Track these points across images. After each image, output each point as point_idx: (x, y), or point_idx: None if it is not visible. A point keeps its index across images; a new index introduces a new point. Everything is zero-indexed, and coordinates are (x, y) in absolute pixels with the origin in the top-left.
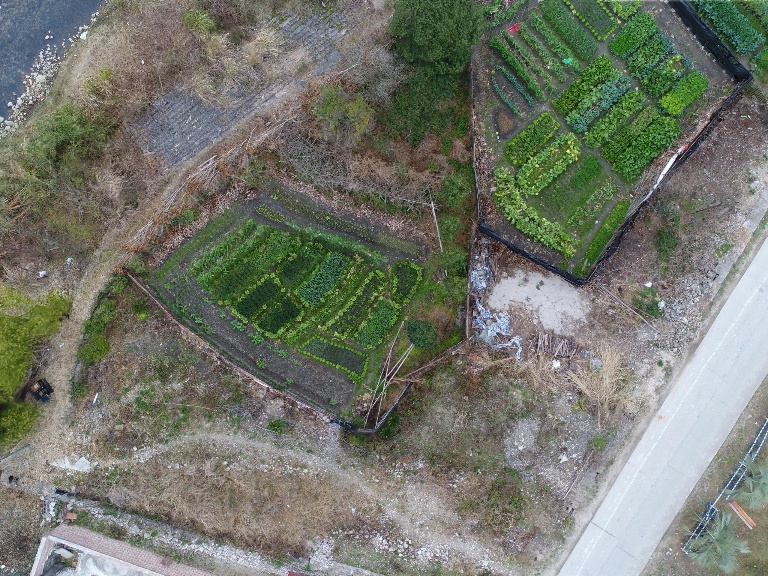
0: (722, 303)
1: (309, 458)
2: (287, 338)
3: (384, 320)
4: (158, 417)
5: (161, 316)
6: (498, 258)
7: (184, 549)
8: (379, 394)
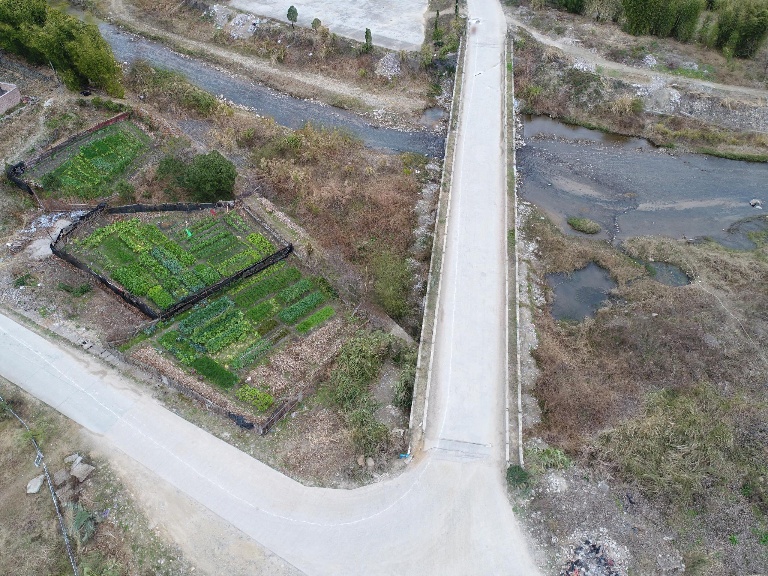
0: (7, 315)
1: None
2: None
3: None
4: None
5: None
6: None
7: None
8: None
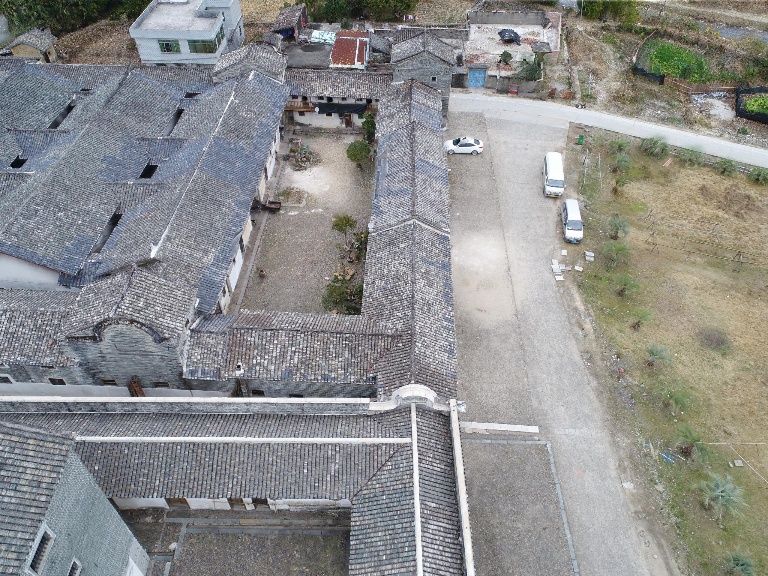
0: (765, 149)
1: None
2: None
3: None
4: None
5: None
6: (729, 99)
7: None
8: None
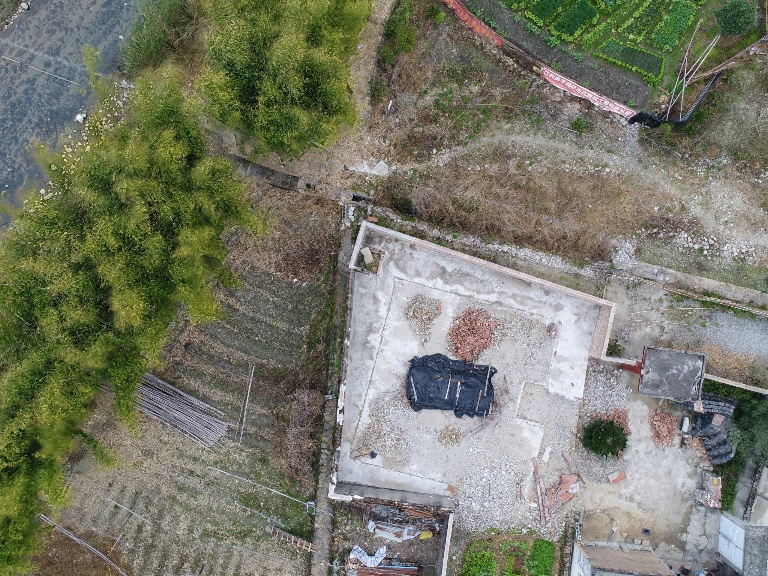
0: None
1: (610, 158)
2: (583, 40)
3: (682, 19)
4: (460, 116)
5: (453, 23)
6: None
7: (487, 250)
8: (677, 95)
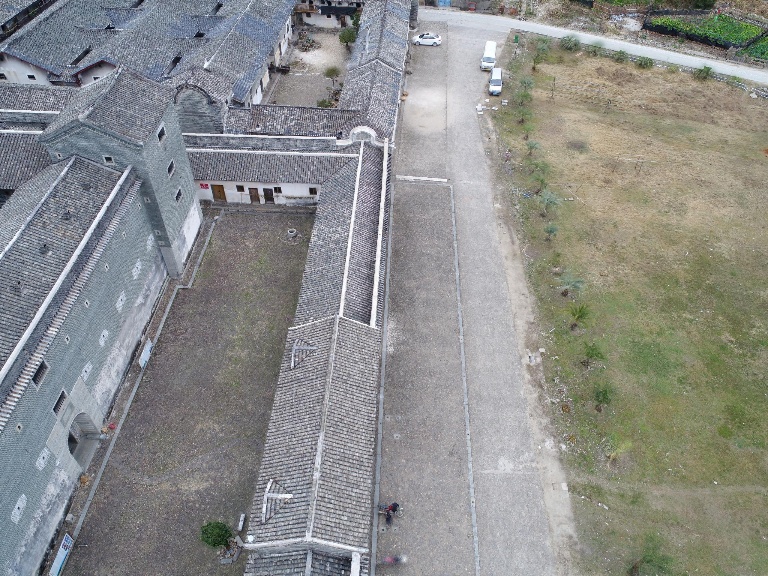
0: None
1: None
2: None
3: None
4: None
5: None
6: None
7: None
8: None
